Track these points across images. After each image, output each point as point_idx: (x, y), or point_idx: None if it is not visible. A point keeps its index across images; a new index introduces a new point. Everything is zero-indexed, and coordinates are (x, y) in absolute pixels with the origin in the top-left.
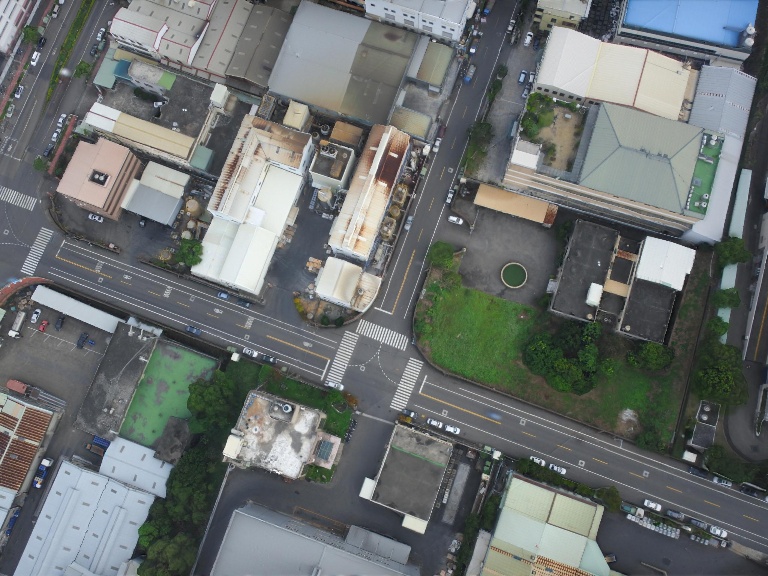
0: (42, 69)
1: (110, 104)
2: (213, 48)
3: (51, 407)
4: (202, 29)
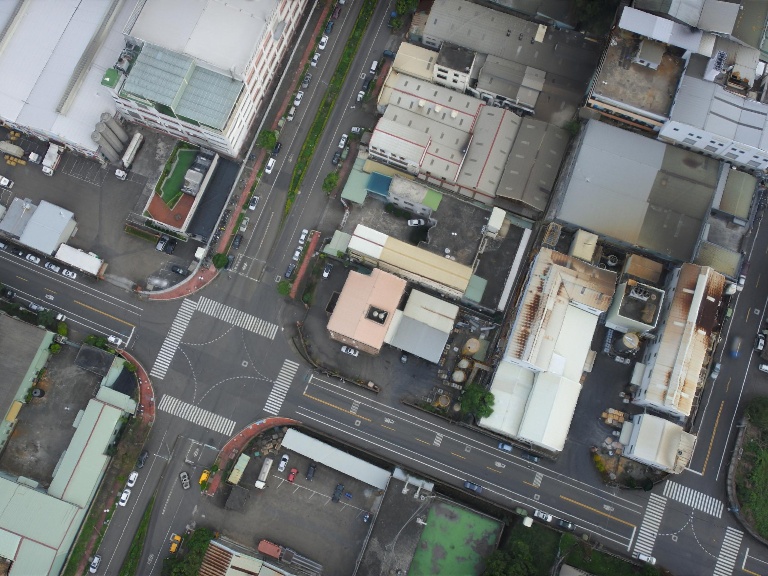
0: (278, 178)
1: (357, 220)
2: (482, 165)
3: (305, 571)
4: (467, 143)
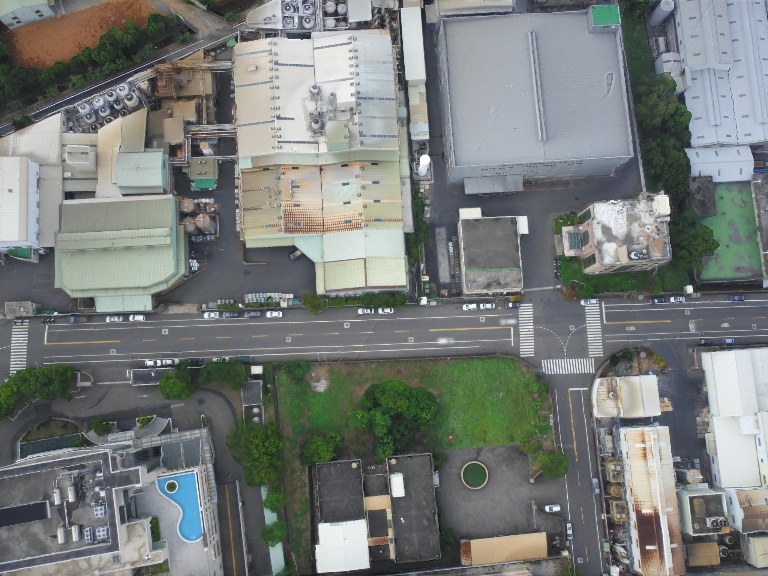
0: None
1: None
2: None
3: None
4: None
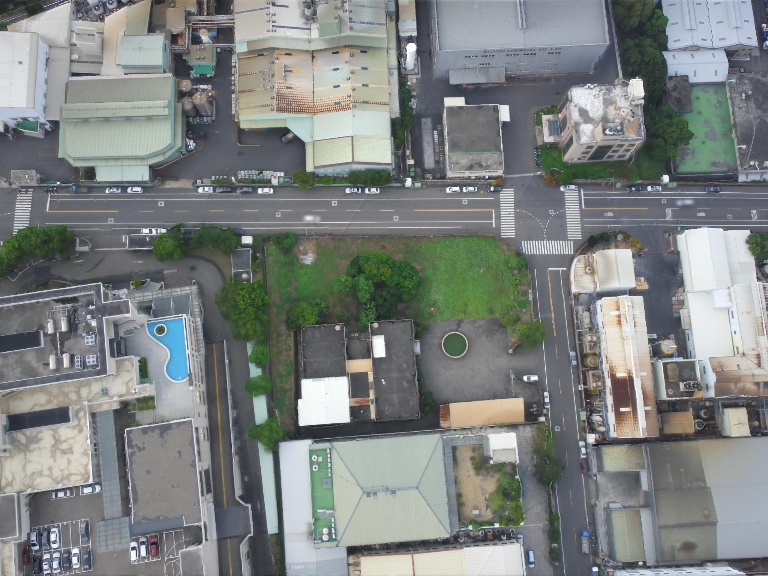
0: None
1: None
2: None
3: None
4: None
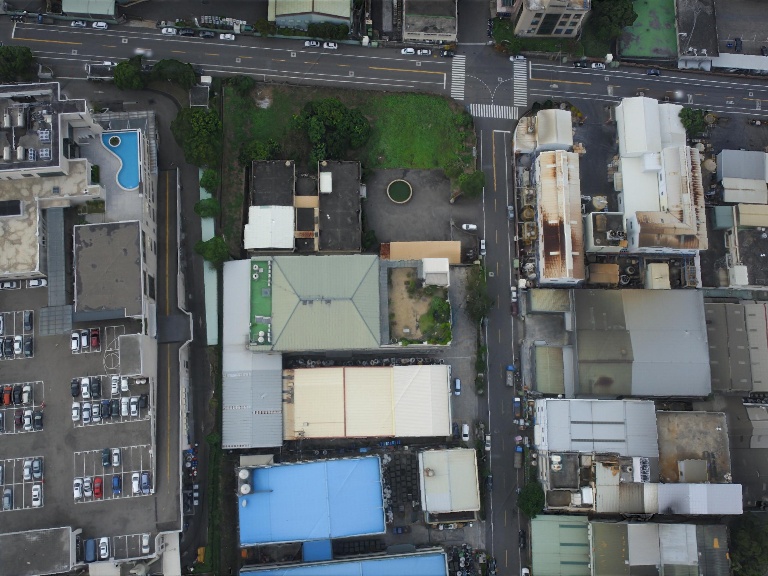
0: None
1: None
2: None
3: None
4: None
